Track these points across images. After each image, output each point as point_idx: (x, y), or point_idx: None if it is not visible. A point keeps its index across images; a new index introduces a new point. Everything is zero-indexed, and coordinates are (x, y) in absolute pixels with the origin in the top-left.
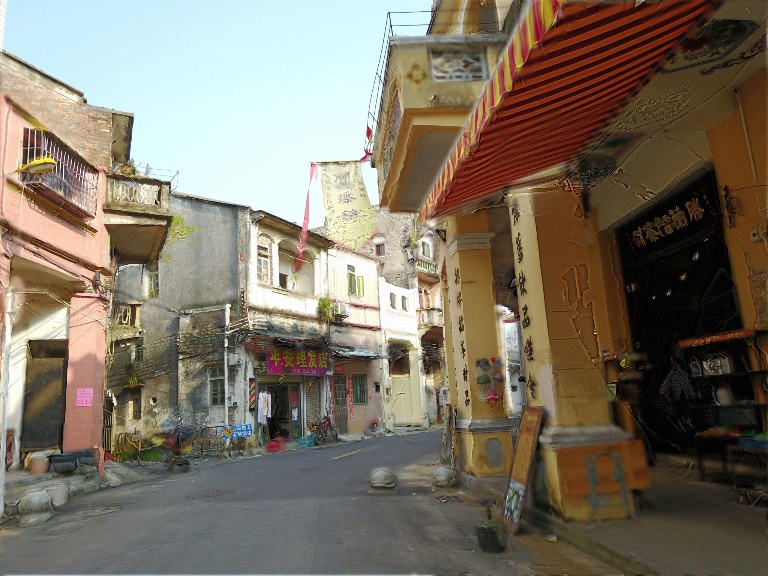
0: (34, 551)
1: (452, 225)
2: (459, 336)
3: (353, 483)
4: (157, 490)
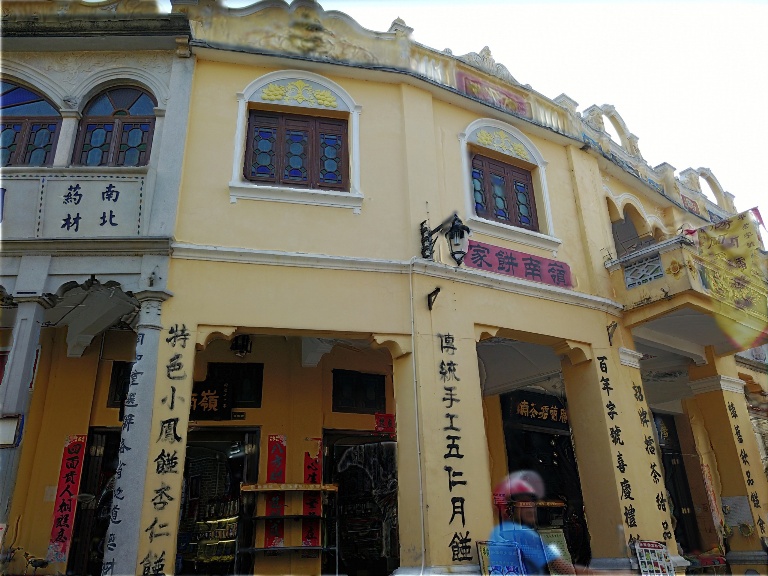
0: None
1: (625, 337)
2: (647, 456)
3: None
4: None
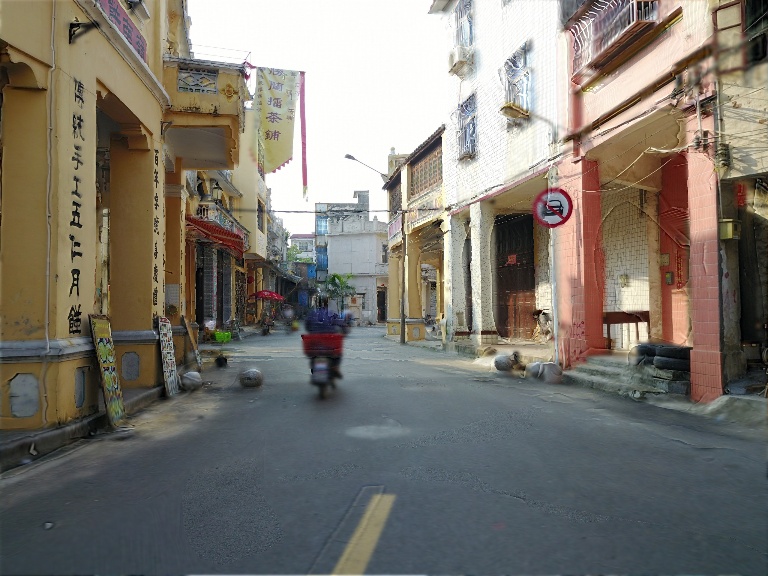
0: (422, 365)
1: None
2: None
3: (280, 389)
4: (520, 393)
